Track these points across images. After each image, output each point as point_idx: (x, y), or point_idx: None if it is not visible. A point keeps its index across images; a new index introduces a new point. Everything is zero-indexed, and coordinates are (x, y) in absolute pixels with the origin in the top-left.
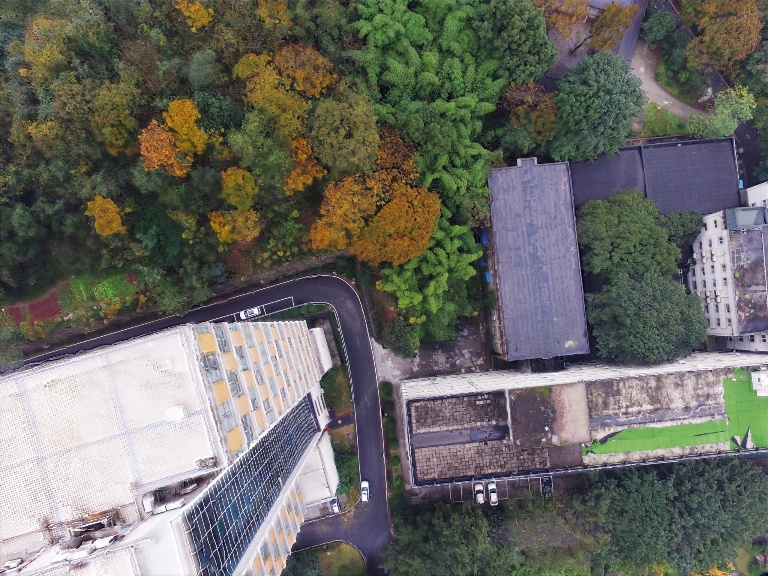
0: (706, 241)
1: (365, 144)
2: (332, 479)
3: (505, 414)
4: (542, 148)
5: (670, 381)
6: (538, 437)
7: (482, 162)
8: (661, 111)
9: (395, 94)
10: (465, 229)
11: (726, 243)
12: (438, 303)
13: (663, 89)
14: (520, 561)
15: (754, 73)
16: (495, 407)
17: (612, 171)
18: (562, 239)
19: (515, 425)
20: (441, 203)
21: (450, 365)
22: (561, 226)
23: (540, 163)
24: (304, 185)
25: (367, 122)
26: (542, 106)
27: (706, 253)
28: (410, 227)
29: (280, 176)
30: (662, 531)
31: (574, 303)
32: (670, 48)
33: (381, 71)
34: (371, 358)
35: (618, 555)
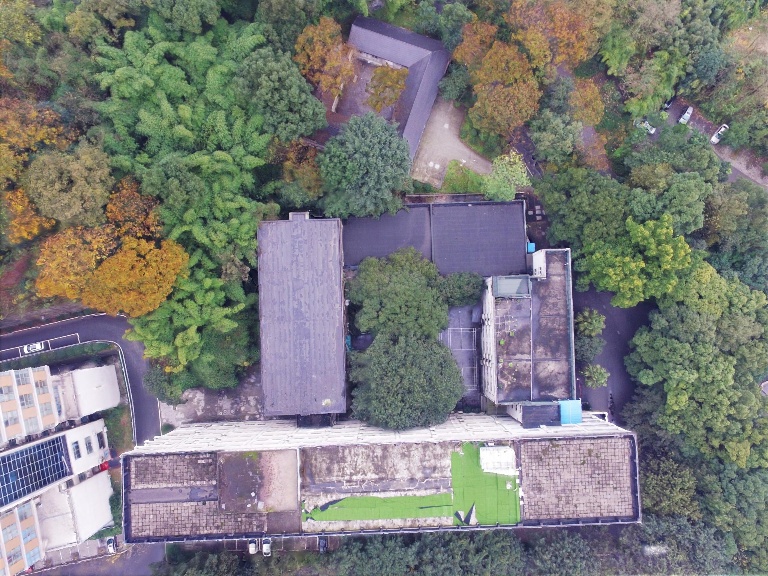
0: (487, 304)
1: (84, 198)
2: (89, 522)
3: None
4: (319, 202)
5: (397, 451)
6: (244, 502)
7: (248, 215)
8: (463, 168)
9: (153, 144)
10: (221, 282)
11: (493, 310)
12: (193, 354)
13: (467, 146)
14: None
15: (533, 140)
16: (216, 467)
17: (400, 227)
18: (328, 296)
19: (221, 489)
20: (203, 254)
21: (235, 411)
22: (328, 283)
23: (311, 218)
24: (31, 234)
25: (91, 176)
26: (304, 163)
27: (487, 316)
28: (136, 282)
29: (5, 224)
30: None
31: (335, 361)
32: (471, 107)
33: (136, 121)
34: (155, 399)
35: None
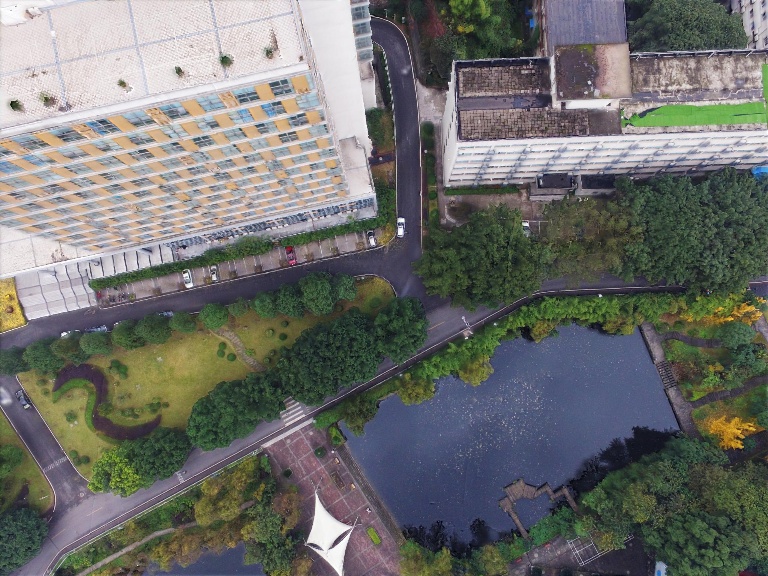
0: None
1: None
2: None
3: (548, 84)
4: None
5: (710, 64)
6: (581, 90)
7: None
8: None
9: None
10: None
11: None
12: (486, 11)
13: None
14: (553, 259)
15: None
16: (539, 77)
17: None
18: None
19: (559, 77)
20: None
21: None
22: None
23: None
24: None
25: None
26: None
27: (745, 2)
28: None
29: None
30: (696, 224)
31: (616, 23)
32: None
33: None
34: (415, 99)
35: (650, 260)
